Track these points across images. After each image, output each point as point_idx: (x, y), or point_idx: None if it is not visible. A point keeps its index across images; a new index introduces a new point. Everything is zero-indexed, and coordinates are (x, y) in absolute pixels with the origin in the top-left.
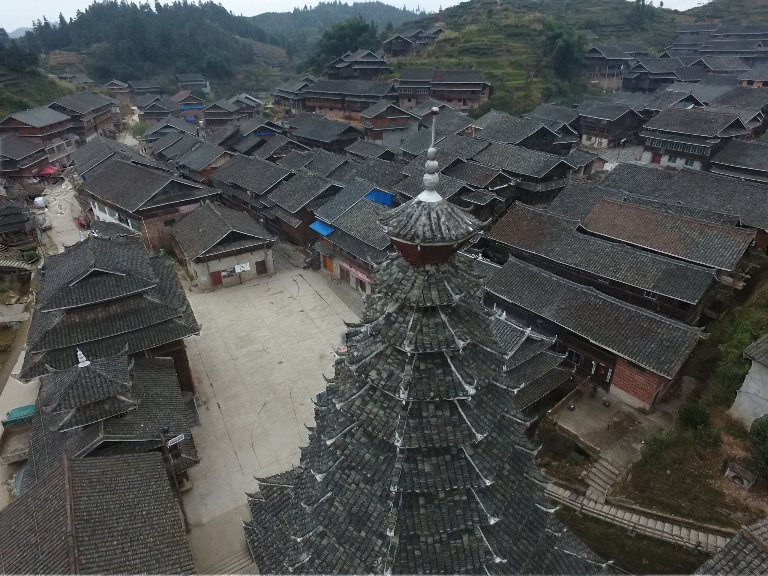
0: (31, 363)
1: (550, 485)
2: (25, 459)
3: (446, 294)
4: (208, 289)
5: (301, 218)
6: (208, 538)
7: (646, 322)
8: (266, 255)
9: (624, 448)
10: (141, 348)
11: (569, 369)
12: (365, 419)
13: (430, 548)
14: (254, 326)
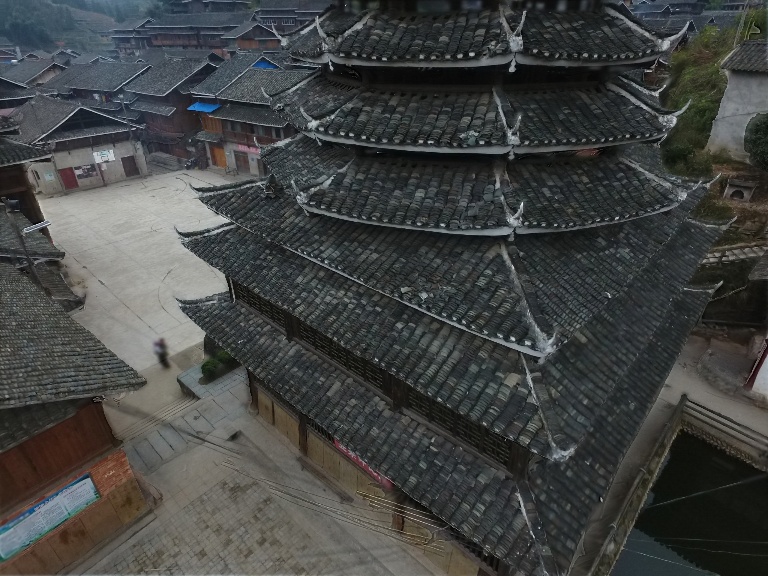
0: None
1: None
2: None
3: None
4: (58, 193)
5: (174, 106)
6: None
7: None
8: (135, 147)
9: None
10: None
11: None
12: None
13: (564, 33)
14: (134, 215)
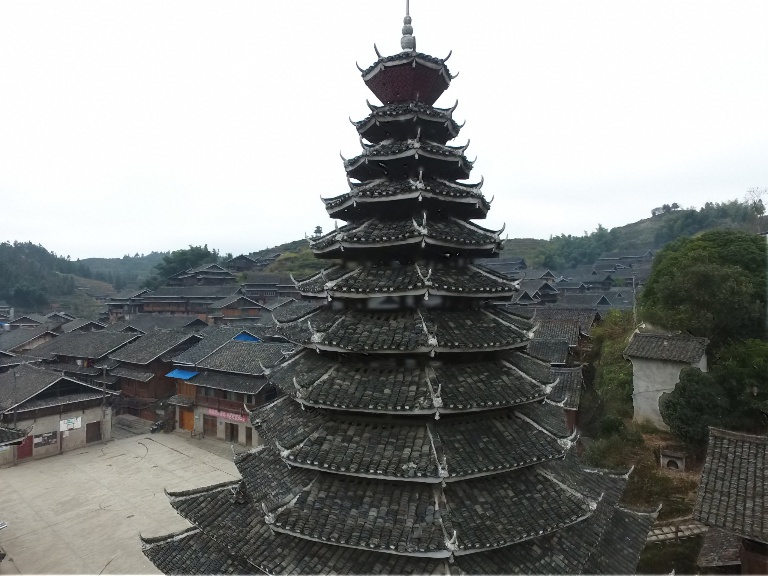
0: None
1: None
2: None
3: None
4: (7, 464)
5: (153, 372)
6: None
7: None
8: (104, 413)
9: None
10: None
11: None
12: None
13: (474, 386)
14: (84, 489)
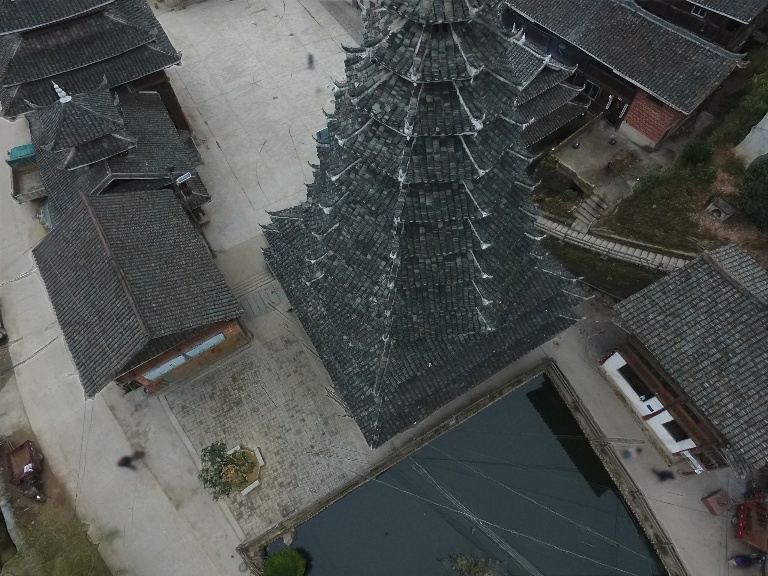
0: (9, 98)
1: (540, 218)
2: (44, 196)
3: (461, 7)
4: (177, 5)
5: None
6: (233, 261)
7: (683, 47)
8: None
9: (618, 185)
10: (121, 81)
11: (583, 104)
12: (369, 156)
13: (427, 267)
14: (239, 54)
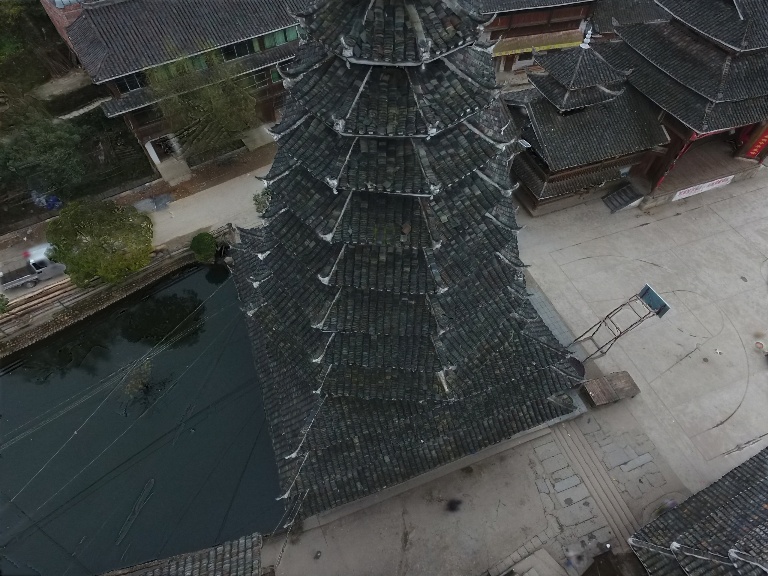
0: None
1: None
2: None
3: None
4: None
5: None
6: None
7: None
8: None
9: None
10: (655, 98)
11: None
12: None
13: None
14: None
